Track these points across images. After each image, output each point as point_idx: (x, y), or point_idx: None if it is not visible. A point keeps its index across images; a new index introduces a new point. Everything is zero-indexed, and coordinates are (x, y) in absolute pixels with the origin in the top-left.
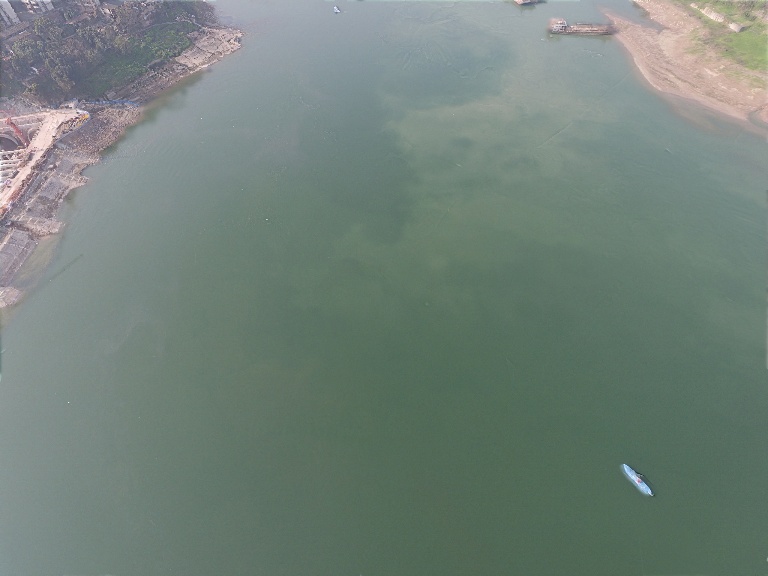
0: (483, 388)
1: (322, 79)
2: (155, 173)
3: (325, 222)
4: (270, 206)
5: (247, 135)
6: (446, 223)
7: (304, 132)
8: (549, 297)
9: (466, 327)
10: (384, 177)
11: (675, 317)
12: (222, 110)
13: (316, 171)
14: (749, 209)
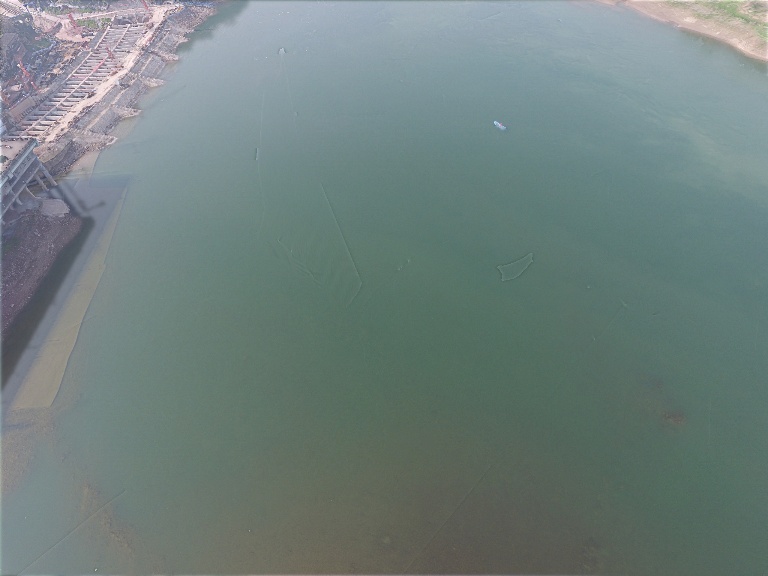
0: (429, 106)
1: None
2: (232, 36)
3: (342, 50)
4: (308, 46)
5: (289, 19)
6: (415, 51)
7: (327, 15)
8: (471, 77)
9: (423, 88)
10: (378, 32)
11: (539, 81)
12: (270, 8)
13: (335, 30)
14: (600, 43)
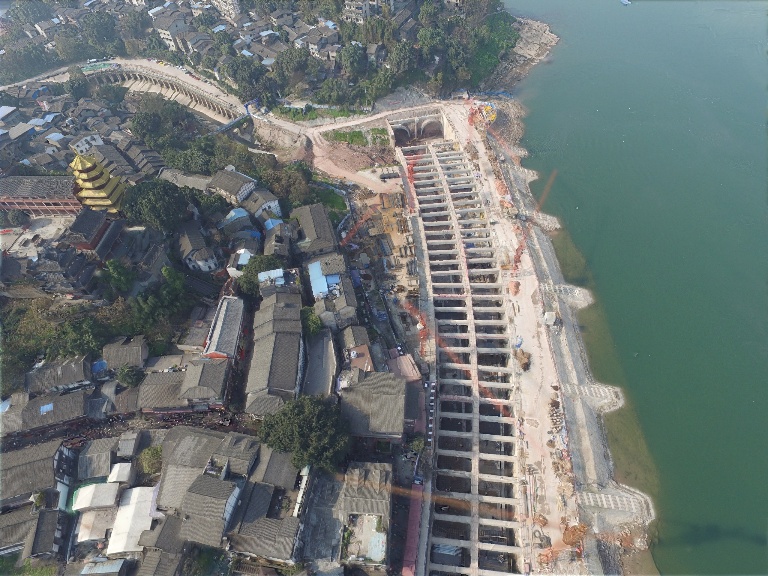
0: None
1: (683, 71)
2: (603, 167)
3: None
4: None
5: (665, 128)
6: None
7: (732, 125)
8: None
9: None
10: None
11: None
12: (608, 102)
13: None
14: None
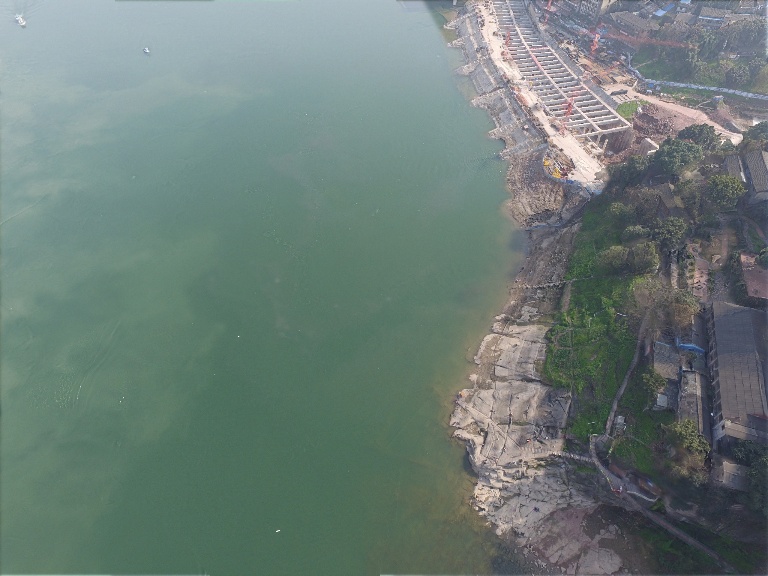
0: (192, 68)
1: (262, 309)
2: (429, 148)
3: (261, 114)
4: (307, 124)
5: (351, 193)
6: None
7: (282, 192)
8: (133, 99)
9: (188, 85)
10: (207, 147)
11: (74, 95)
12: (401, 230)
13: (267, 147)
14: None
